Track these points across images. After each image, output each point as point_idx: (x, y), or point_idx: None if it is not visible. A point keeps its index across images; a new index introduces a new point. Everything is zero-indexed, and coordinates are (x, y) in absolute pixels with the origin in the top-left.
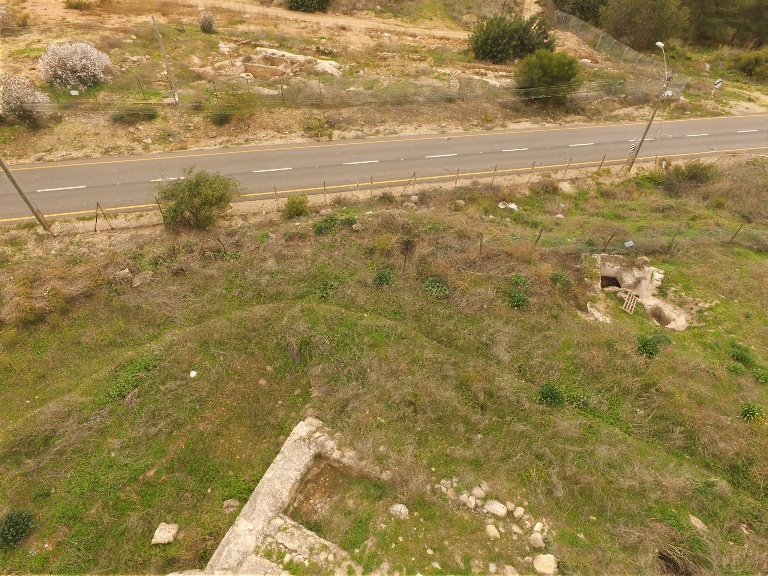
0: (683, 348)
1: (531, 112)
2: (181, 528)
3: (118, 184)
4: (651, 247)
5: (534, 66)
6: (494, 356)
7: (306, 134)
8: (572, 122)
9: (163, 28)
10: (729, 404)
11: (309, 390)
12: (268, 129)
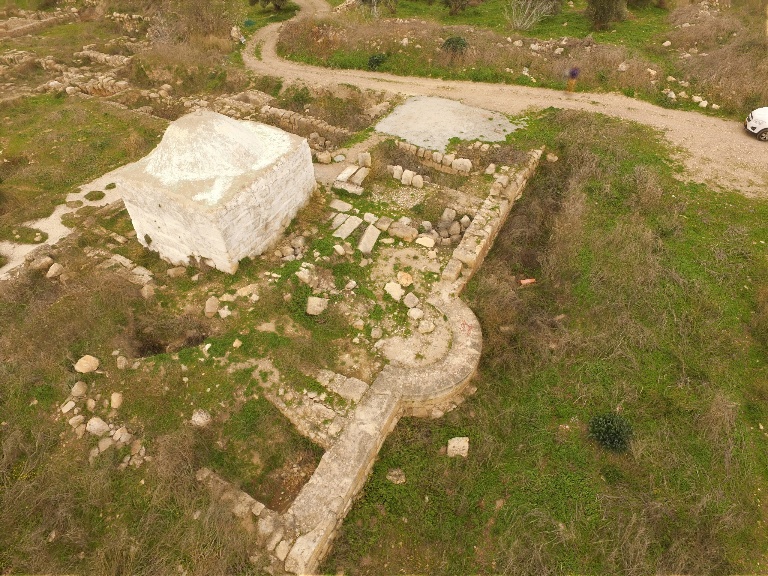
0: None
1: None
2: None
3: None
4: None
5: None
6: None
7: None
8: None
9: None
10: None
11: None
12: None
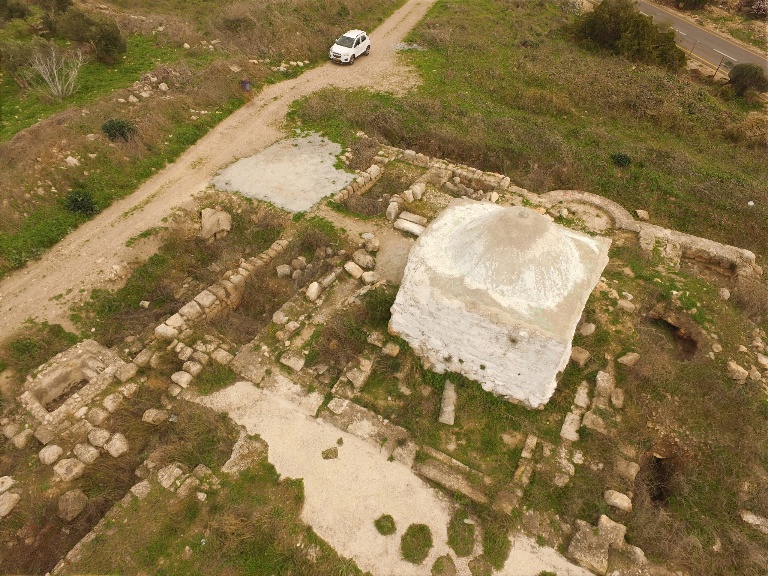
0: None
1: None
2: None
3: None
4: None
5: None
6: None
7: None
8: None
9: None
10: None
11: None
12: None
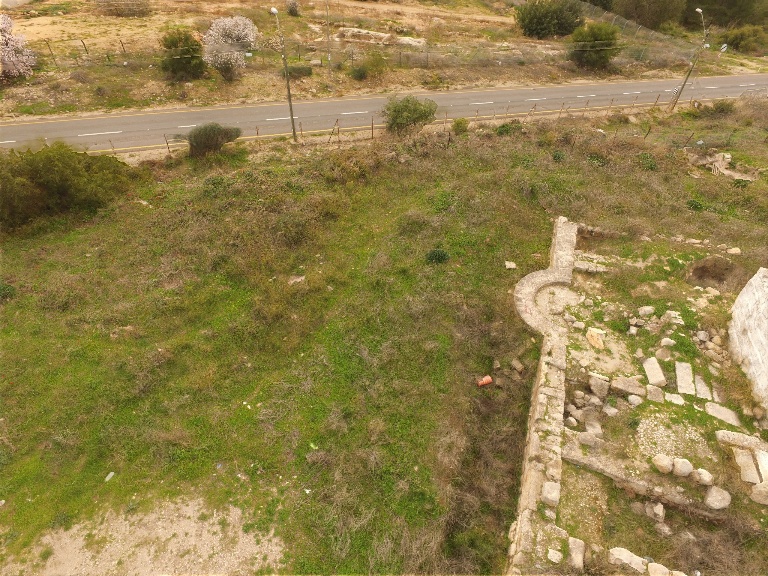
0: (759, 186)
1: (583, 73)
2: (516, 264)
3: (319, 116)
4: (715, 144)
5: (586, 35)
6: (652, 189)
7: (425, 87)
8: (616, 79)
9: (330, 1)
10: None
11: (545, 211)
12: (395, 83)
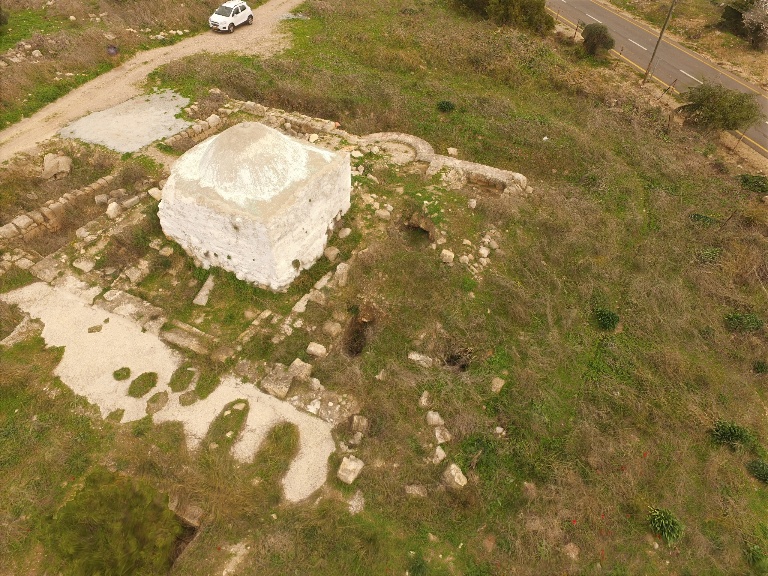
0: (767, 502)
1: None
2: (456, 157)
3: None
4: None
5: None
6: None
7: None
8: None
9: None
10: (673, 508)
11: None
12: None
